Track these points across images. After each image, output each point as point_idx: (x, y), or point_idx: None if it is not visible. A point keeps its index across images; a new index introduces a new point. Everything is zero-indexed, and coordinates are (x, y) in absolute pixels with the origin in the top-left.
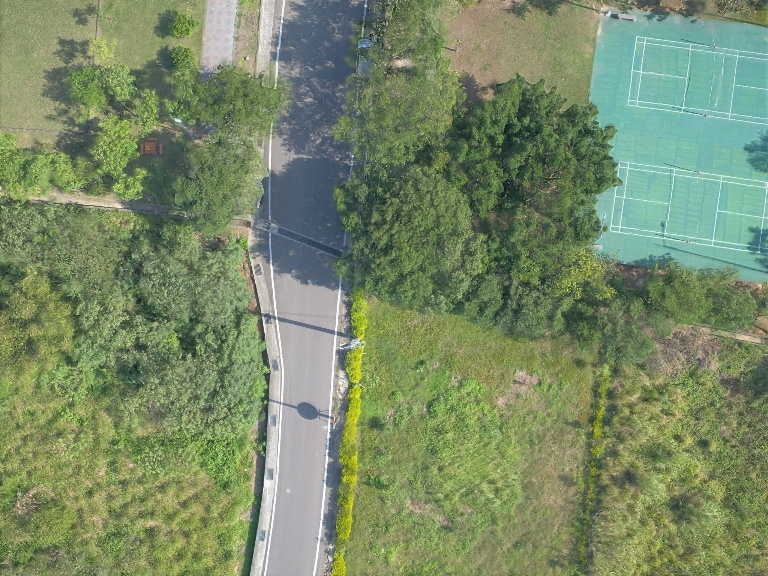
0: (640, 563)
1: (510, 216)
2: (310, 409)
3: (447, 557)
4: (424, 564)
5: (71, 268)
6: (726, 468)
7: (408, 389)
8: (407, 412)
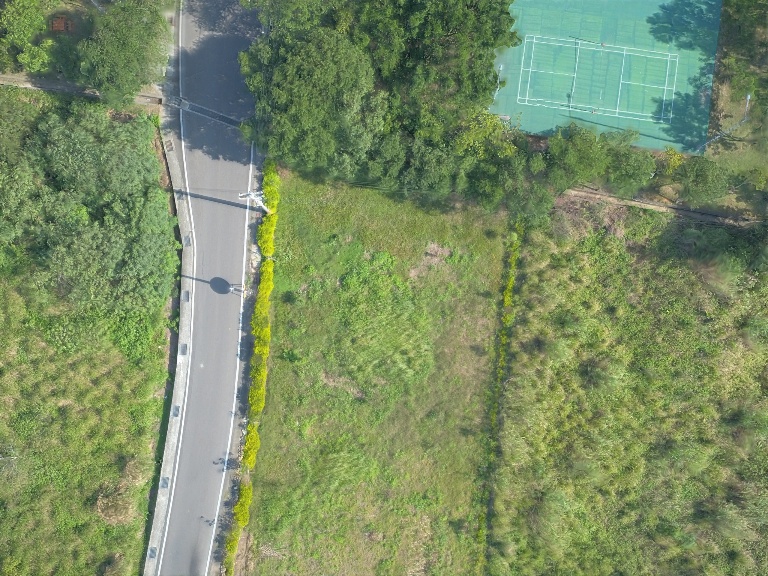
0: (550, 428)
1: (411, 74)
2: (223, 283)
3: (361, 428)
4: (338, 436)
5: None
6: (633, 334)
7: (321, 263)
8: (320, 286)
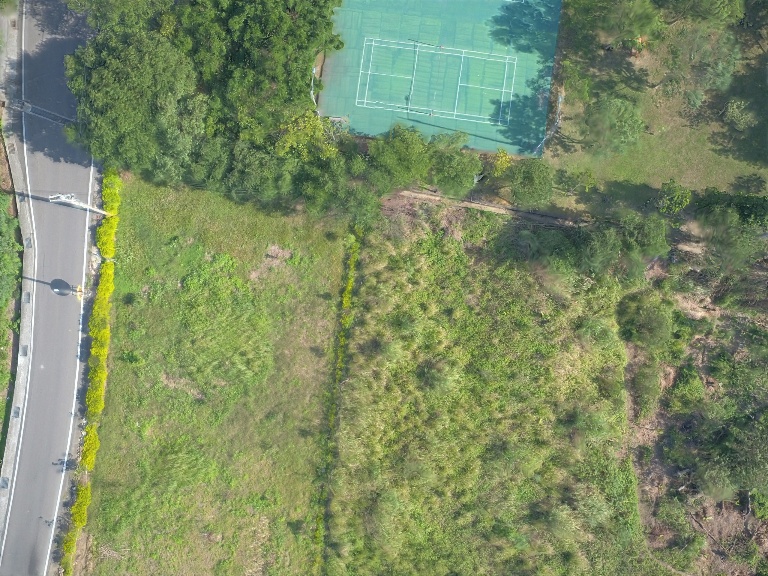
0: (388, 430)
1: None
2: (63, 285)
3: (201, 429)
4: (178, 437)
5: None
6: (471, 335)
7: (162, 264)
8: (161, 287)
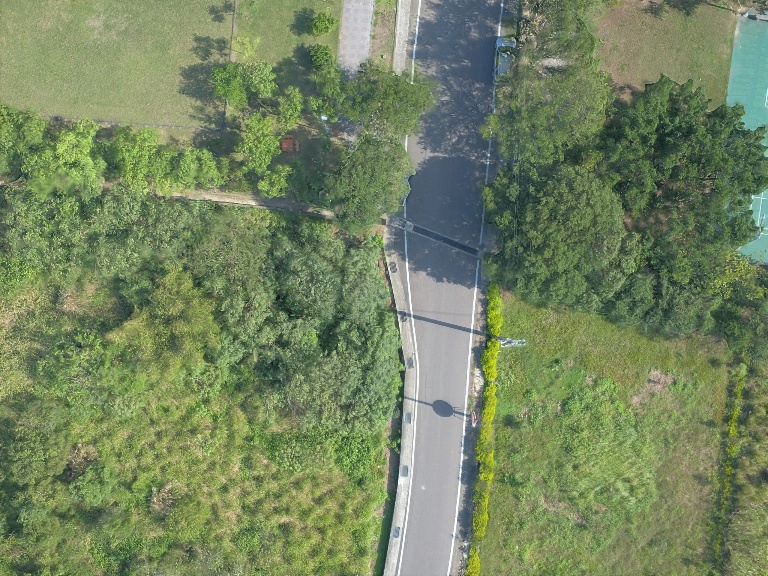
0: None
1: (663, 216)
2: (445, 407)
3: (581, 555)
4: (558, 562)
5: (210, 264)
6: None
7: (543, 387)
8: (542, 410)
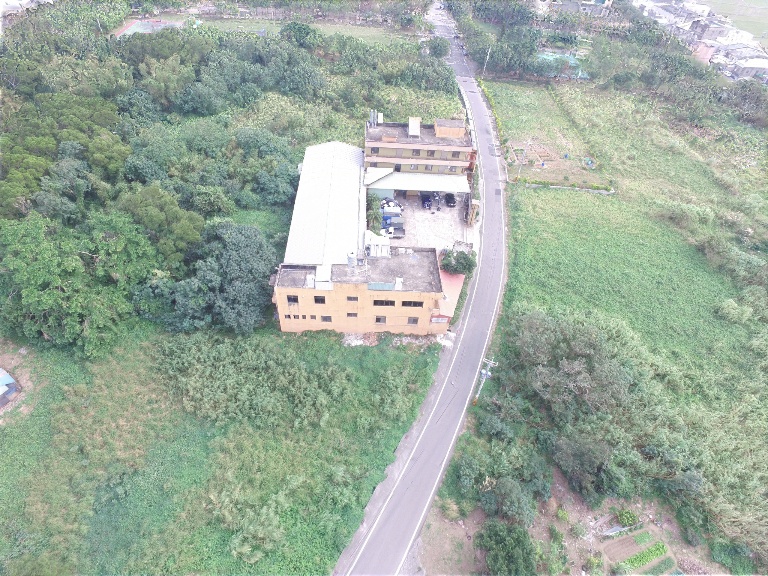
0: None
1: None
2: None
3: None
4: None
5: None
6: None
7: None
8: None
